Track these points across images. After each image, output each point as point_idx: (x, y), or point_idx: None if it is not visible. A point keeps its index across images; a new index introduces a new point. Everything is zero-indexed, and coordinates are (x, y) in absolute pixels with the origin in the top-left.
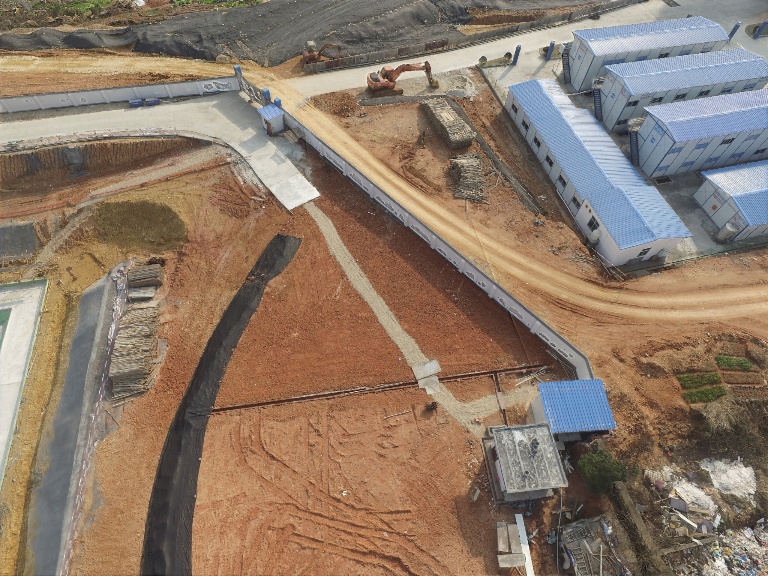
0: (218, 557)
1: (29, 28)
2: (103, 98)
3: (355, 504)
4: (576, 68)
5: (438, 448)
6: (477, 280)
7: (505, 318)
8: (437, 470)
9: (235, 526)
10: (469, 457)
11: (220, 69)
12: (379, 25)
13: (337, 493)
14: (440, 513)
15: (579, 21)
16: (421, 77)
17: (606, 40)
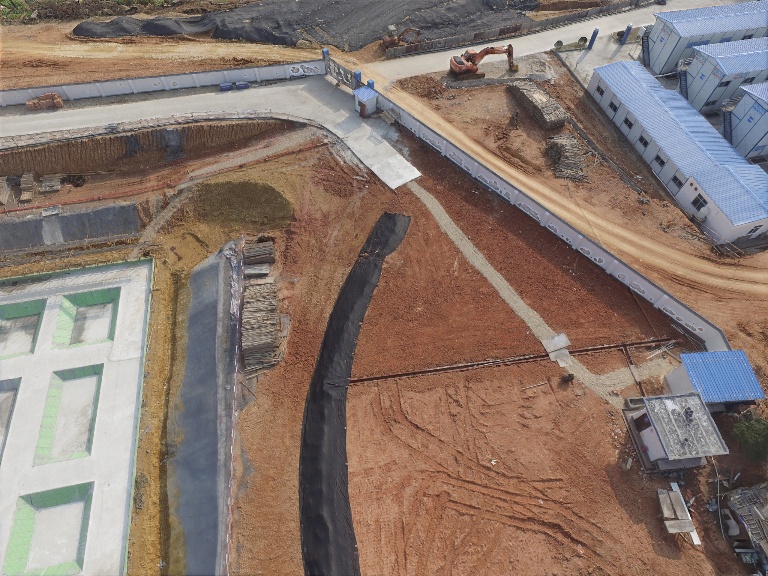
0: (379, 522)
1: (106, 16)
2: (194, 82)
3: (506, 472)
4: (657, 51)
5: (580, 419)
6: (593, 256)
7: (625, 293)
8: (582, 440)
9: (391, 493)
10: (612, 428)
11: (301, 54)
12: (451, 11)
13: (486, 462)
14: (592, 482)
15: (646, 7)
16: (499, 61)
17: (691, 22)
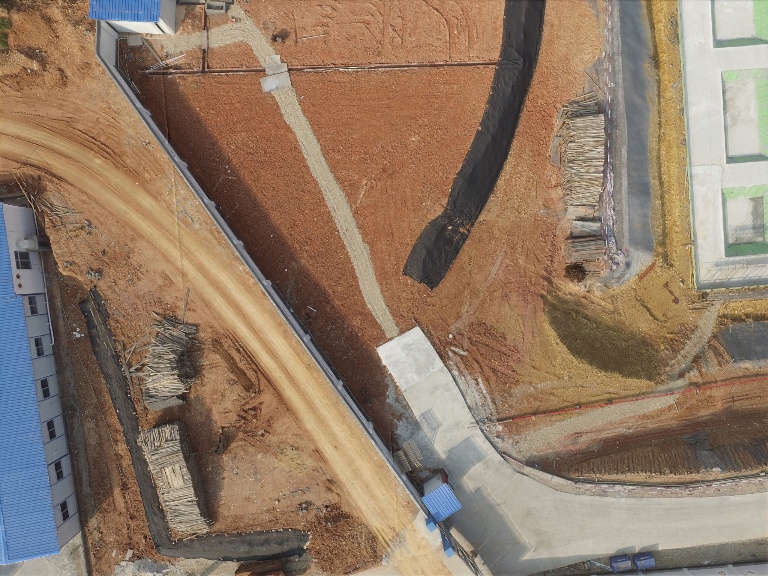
0: None
1: None
2: (694, 575)
3: None
4: None
5: None
6: None
7: (176, 136)
8: None
9: None
10: None
11: None
12: None
13: None
14: None
15: None
16: None
17: None
